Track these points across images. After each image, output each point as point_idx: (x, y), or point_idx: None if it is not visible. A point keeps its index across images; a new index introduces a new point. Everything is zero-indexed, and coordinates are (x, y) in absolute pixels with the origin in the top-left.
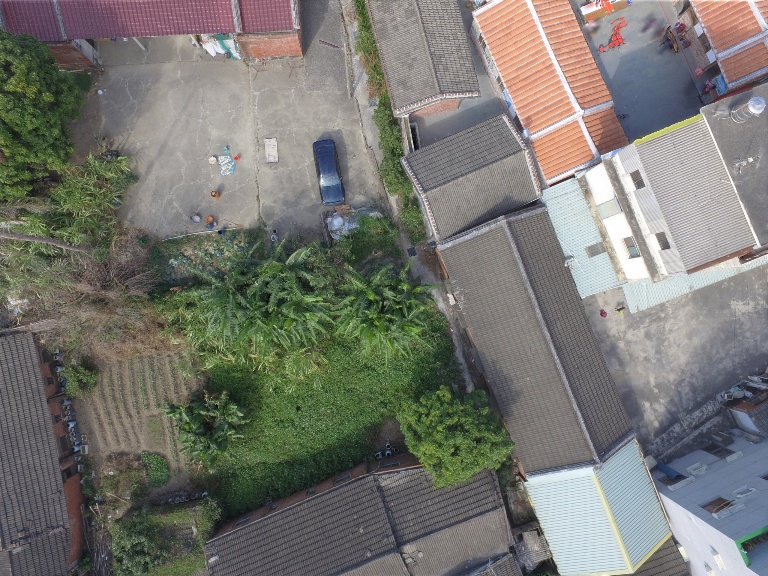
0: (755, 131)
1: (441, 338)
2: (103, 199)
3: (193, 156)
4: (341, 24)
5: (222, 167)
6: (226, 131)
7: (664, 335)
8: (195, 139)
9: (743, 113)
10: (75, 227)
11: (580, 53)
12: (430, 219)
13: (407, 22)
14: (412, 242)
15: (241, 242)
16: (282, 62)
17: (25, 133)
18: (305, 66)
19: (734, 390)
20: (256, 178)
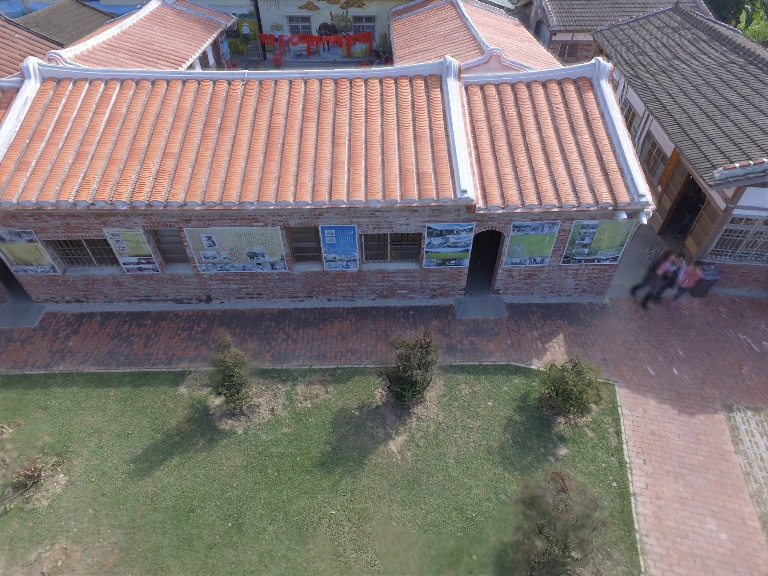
0: None
1: None
2: None
3: None
4: None
5: None
6: None
7: None
8: None
9: None
10: None
11: None
12: None
13: None
14: None
15: None
16: None
17: None
18: None
19: None
20: None
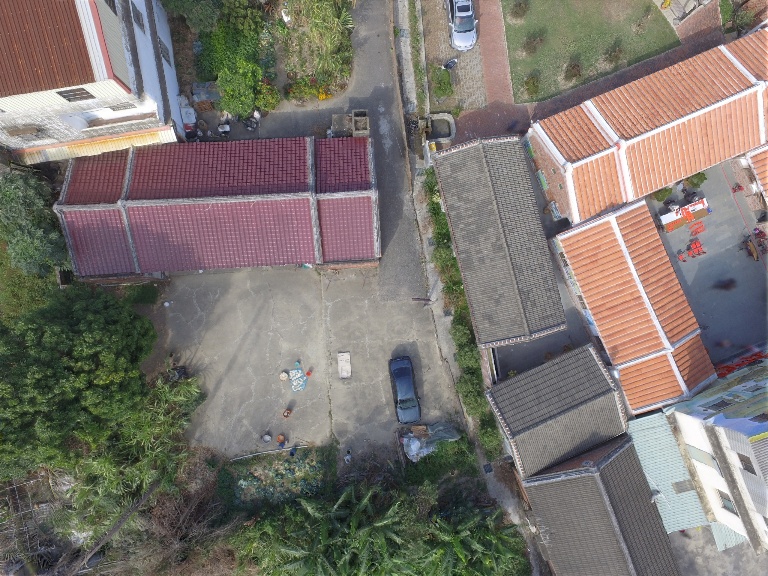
0: None
1: (520, 563)
2: (172, 425)
3: (263, 371)
4: (416, 231)
5: (293, 382)
6: (297, 344)
7: (742, 550)
8: (265, 353)
9: None
10: (146, 465)
11: (667, 280)
12: (517, 460)
13: (494, 256)
14: (489, 459)
15: (313, 461)
16: (355, 271)
17: (111, 416)
18: (379, 275)
19: None
20: (328, 393)
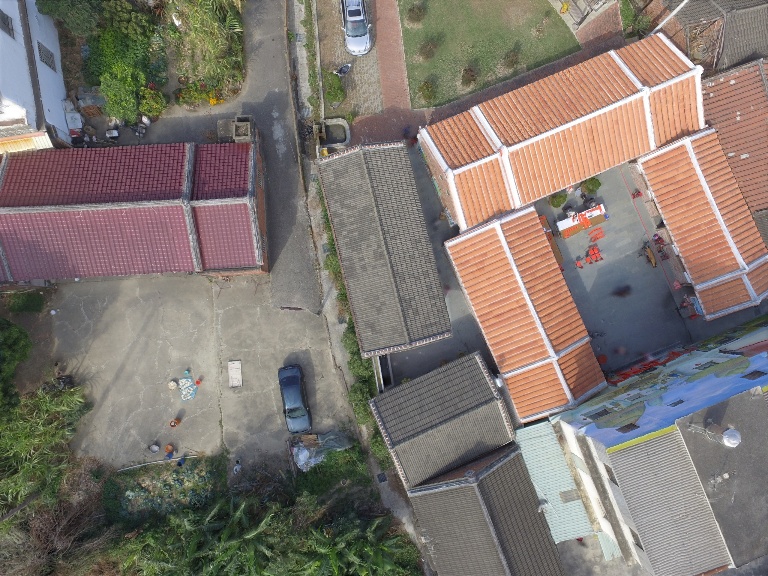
0: None
1: (411, 573)
2: (54, 435)
3: (152, 380)
4: (309, 237)
5: (183, 391)
6: (187, 352)
7: None
8: (154, 362)
9: (718, 440)
10: (22, 477)
11: (555, 287)
12: (399, 470)
13: (376, 264)
14: (382, 469)
15: (202, 471)
16: (247, 278)
17: None
18: (271, 282)
19: None
20: (219, 402)
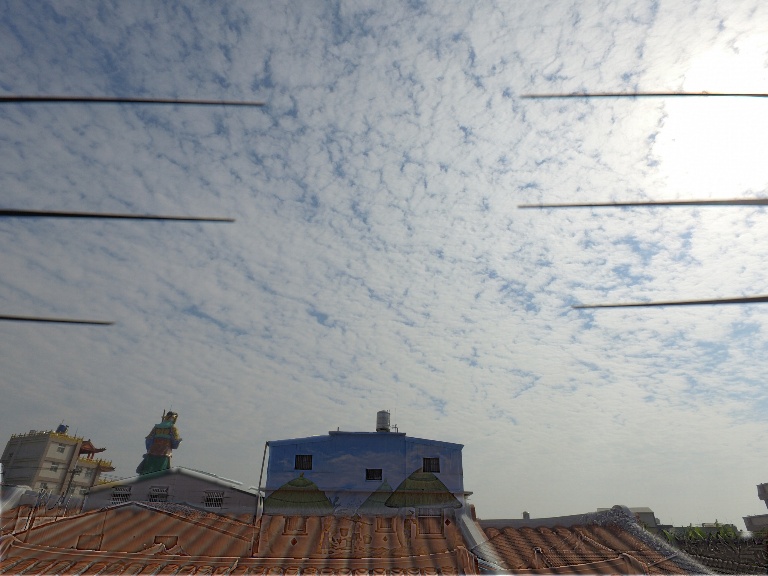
0: None
1: None
2: None
3: None
4: None
5: None
6: None
7: None
8: None
9: None
10: None
11: None
12: None
13: None
14: None
15: None
16: None
17: None
18: None
19: None
20: None
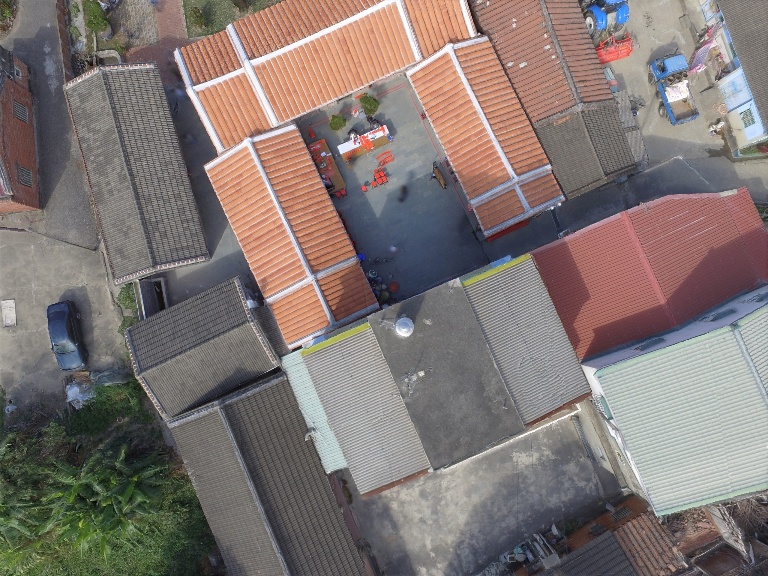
0: (426, 341)
1: (191, 511)
2: None
3: None
4: (84, 172)
5: None
6: None
7: (440, 493)
8: None
9: None
10: None
11: (318, 207)
12: (151, 399)
13: (121, 187)
14: None
15: None
16: (21, 216)
17: None
18: (46, 219)
19: (516, 552)
20: None
